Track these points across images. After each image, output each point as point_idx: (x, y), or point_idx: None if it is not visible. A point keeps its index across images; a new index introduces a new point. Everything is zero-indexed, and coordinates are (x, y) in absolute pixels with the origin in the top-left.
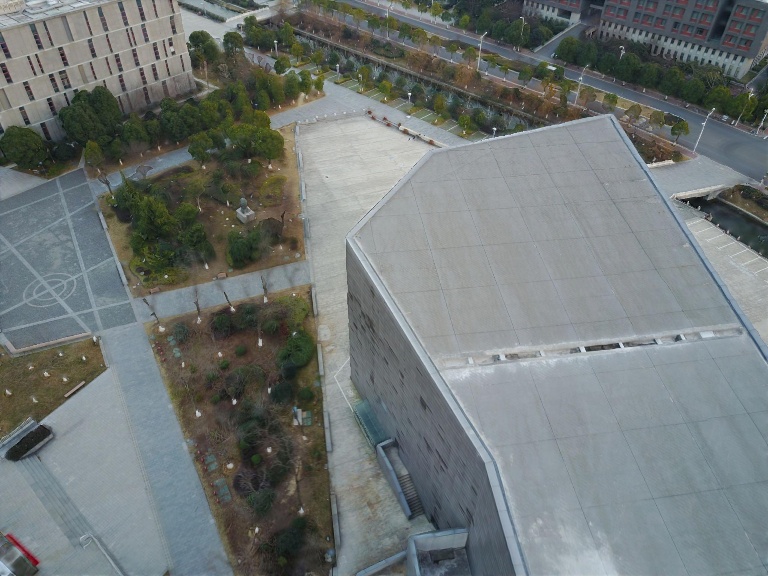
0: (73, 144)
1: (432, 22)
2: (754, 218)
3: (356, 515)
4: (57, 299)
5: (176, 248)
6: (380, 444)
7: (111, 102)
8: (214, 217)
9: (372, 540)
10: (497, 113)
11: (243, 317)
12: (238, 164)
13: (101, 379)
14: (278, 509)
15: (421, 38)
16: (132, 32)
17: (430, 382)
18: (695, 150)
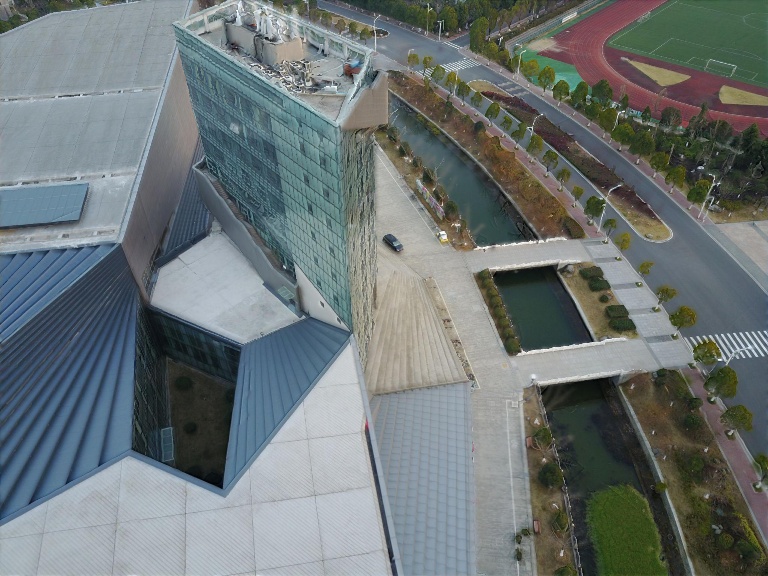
0: None
1: None
2: (389, 91)
3: None
4: None
5: None
6: None
7: None
8: None
9: None
10: None
11: None
12: None
13: None
14: None
15: None
16: None
17: None
18: (379, 51)
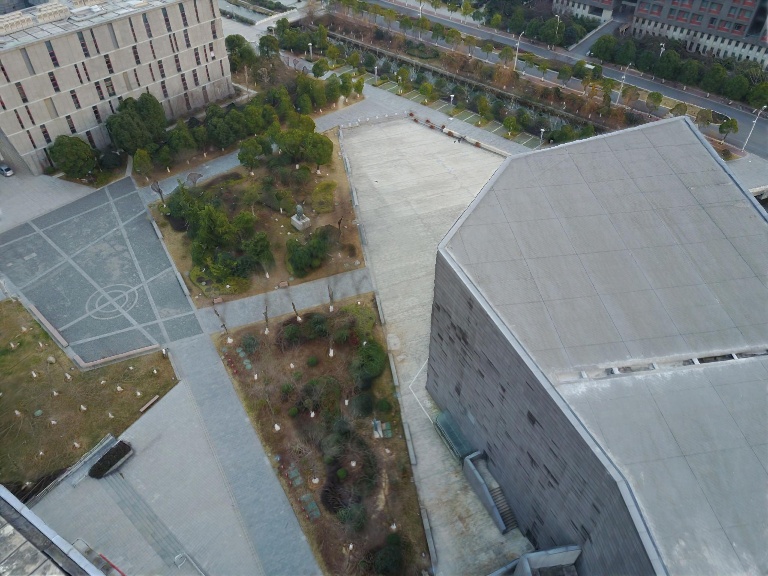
0: (118, 152)
1: (462, 21)
2: None
3: (449, 530)
4: (120, 311)
5: (237, 257)
6: (468, 457)
7: (157, 109)
8: (269, 224)
9: (468, 555)
10: (537, 113)
11: (311, 327)
12: (288, 170)
13: (174, 392)
14: (370, 525)
15: (455, 38)
16: (174, 38)
17: (545, 397)
18: (744, 148)
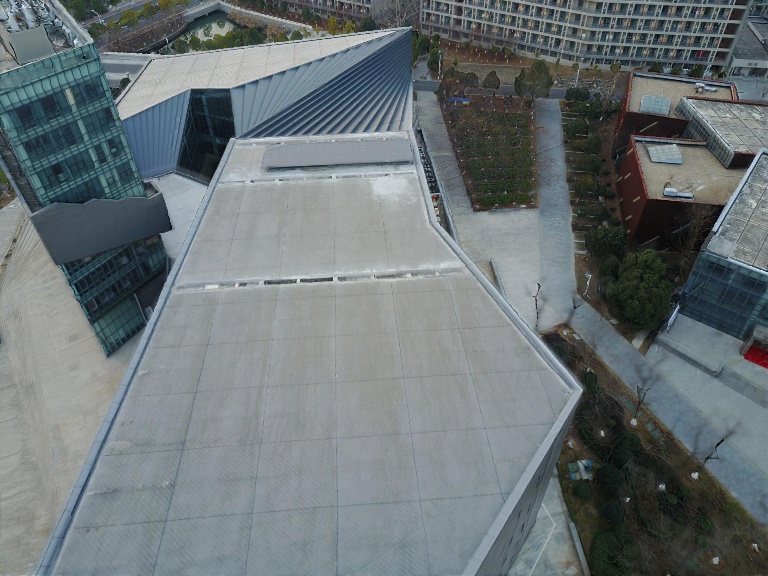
0: None
1: None
2: None
3: None
4: None
5: None
6: None
7: None
8: None
9: None
10: None
11: None
12: None
13: None
14: None
15: None
16: None
17: None
18: None
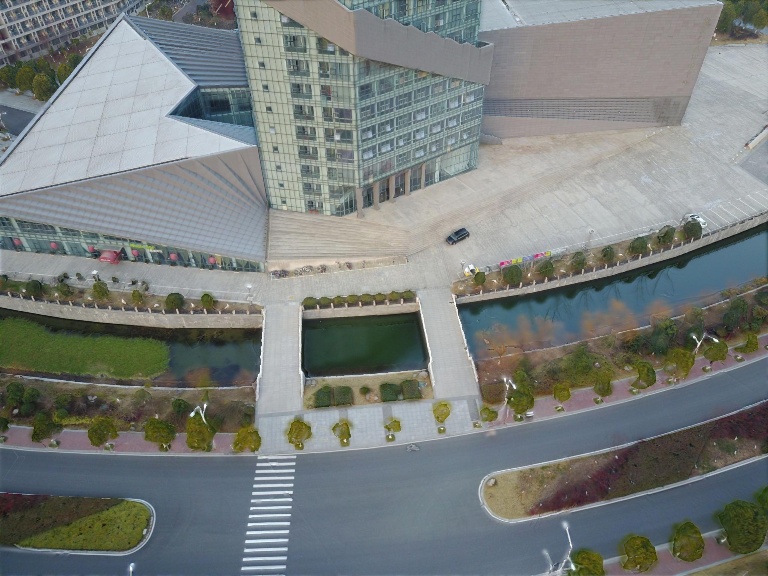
0: None
1: None
2: None
3: None
4: None
5: None
6: None
7: None
8: None
9: None
10: None
11: None
12: None
13: None
14: None
15: None
16: None
17: None
18: None
